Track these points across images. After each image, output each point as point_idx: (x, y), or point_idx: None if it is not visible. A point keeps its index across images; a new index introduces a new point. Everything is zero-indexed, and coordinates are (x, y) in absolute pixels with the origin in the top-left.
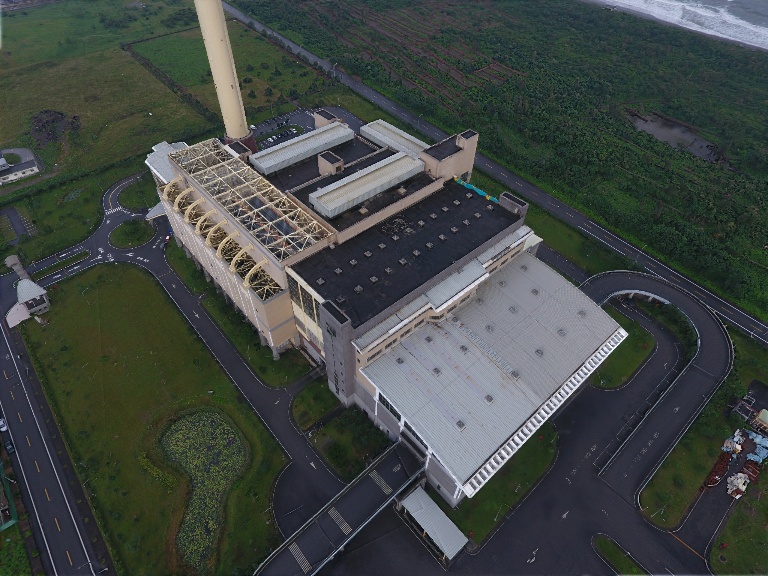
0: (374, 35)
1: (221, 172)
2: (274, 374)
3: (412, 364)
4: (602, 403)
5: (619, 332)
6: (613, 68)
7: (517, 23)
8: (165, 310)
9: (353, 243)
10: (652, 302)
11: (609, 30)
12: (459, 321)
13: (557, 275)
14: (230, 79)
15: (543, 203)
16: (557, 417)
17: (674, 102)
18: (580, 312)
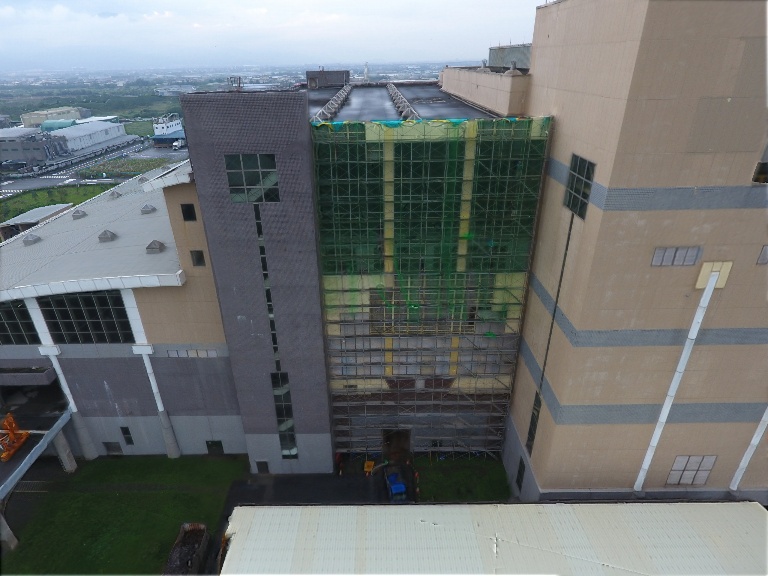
0: None
1: None
2: None
3: None
4: None
5: None
6: None
7: None
8: None
9: None
10: None
11: None
12: None
13: None
14: None
15: None
16: None
17: None
18: None
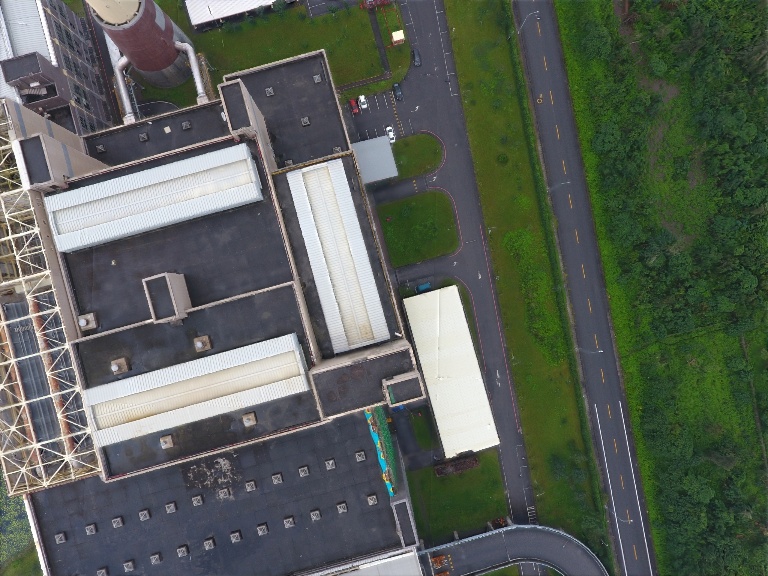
0: None
1: (6, 198)
2: None
3: None
4: None
5: None
6: None
7: None
8: None
9: (135, 482)
10: None
11: None
12: None
13: None
14: None
15: (585, 333)
16: None
17: None
18: None
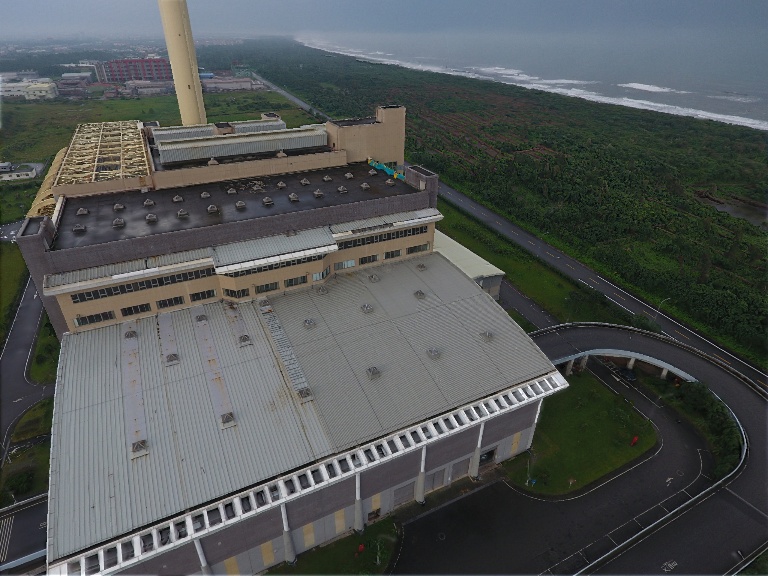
0: (422, 123)
1: None
2: (49, 367)
3: (145, 342)
4: (514, 517)
5: (551, 377)
6: (684, 157)
7: (579, 123)
8: (10, 286)
9: (174, 191)
10: (667, 379)
11: (688, 131)
12: (269, 306)
13: (471, 283)
14: (187, 78)
15: (538, 252)
16: (415, 521)
17: (761, 184)
18: (483, 332)
